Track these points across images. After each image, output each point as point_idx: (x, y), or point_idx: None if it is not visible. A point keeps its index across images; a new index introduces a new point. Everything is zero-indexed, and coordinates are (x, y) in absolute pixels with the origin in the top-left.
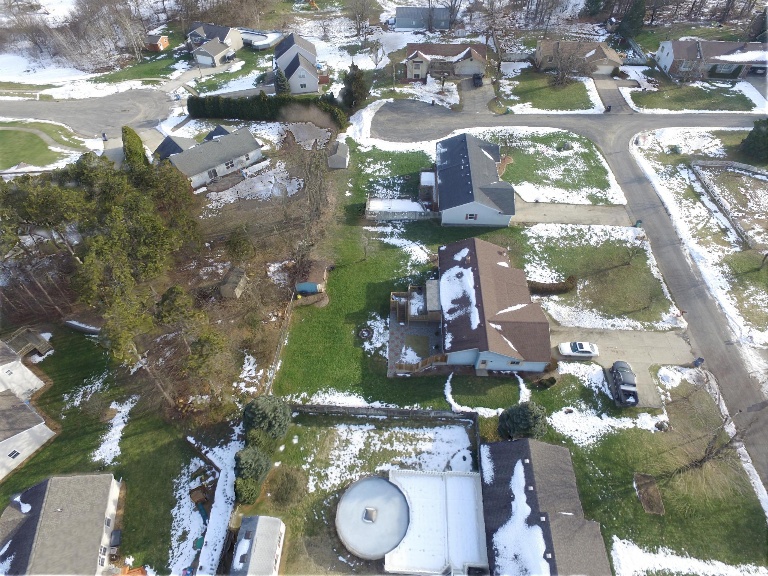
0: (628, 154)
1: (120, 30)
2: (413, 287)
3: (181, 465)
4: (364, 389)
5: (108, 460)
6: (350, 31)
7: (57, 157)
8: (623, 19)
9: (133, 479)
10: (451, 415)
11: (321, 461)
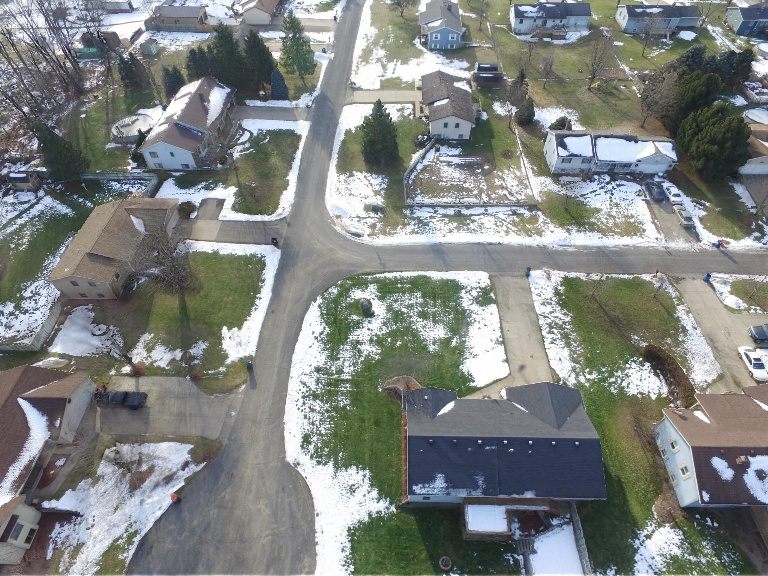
0: (383, 248)
1: None
2: None
3: None
4: None
5: None
6: None
7: None
8: (50, 165)
9: None
10: None
11: None
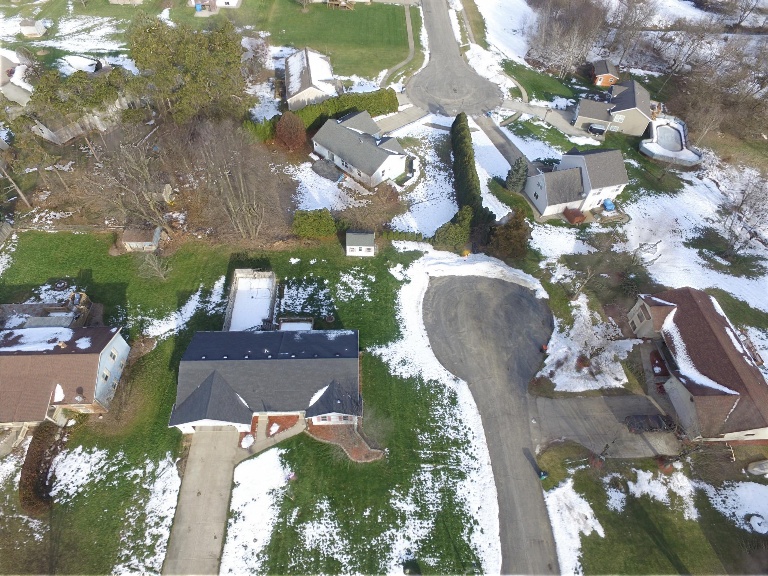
0: None
1: None
2: None
3: None
4: None
5: None
6: None
7: (368, 76)
8: None
9: (3, 182)
10: None
11: None
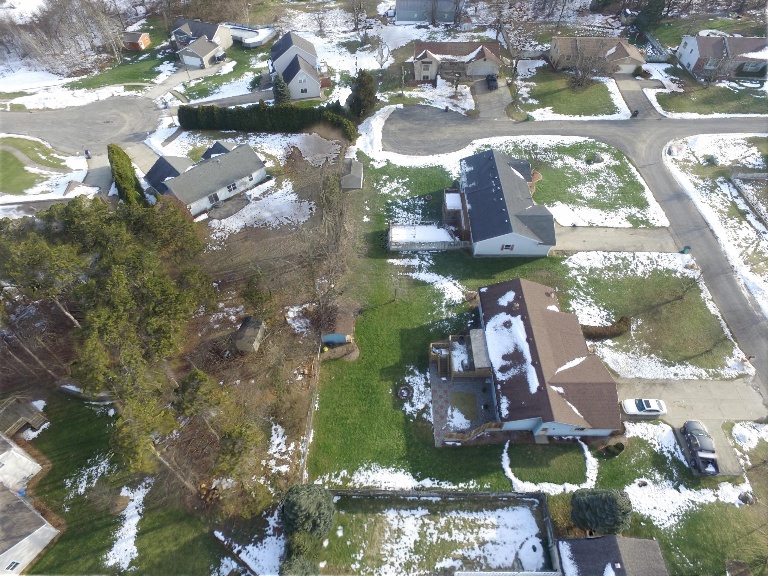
0: (663, 166)
1: (95, 26)
2: (454, 336)
3: (210, 568)
4: (411, 463)
5: (124, 564)
6: (347, 25)
7: (35, 180)
8: (641, 12)
9: None
10: (514, 495)
11: (372, 558)
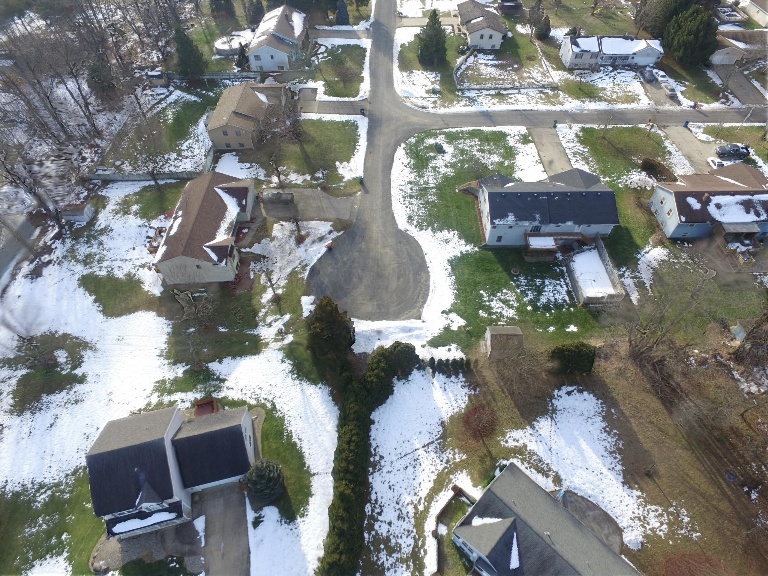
0: (445, 115)
1: None
2: None
3: None
4: None
5: None
6: None
7: None
8: (183, 62)
9: None
10: None
11: None
